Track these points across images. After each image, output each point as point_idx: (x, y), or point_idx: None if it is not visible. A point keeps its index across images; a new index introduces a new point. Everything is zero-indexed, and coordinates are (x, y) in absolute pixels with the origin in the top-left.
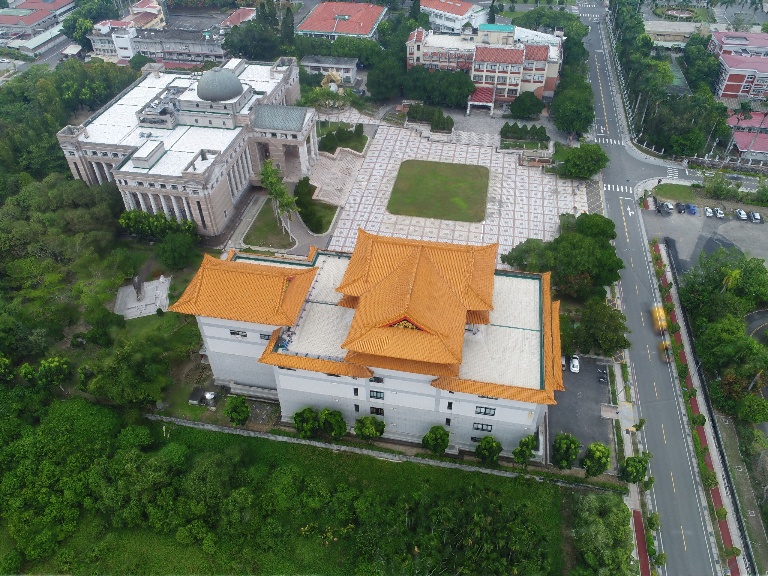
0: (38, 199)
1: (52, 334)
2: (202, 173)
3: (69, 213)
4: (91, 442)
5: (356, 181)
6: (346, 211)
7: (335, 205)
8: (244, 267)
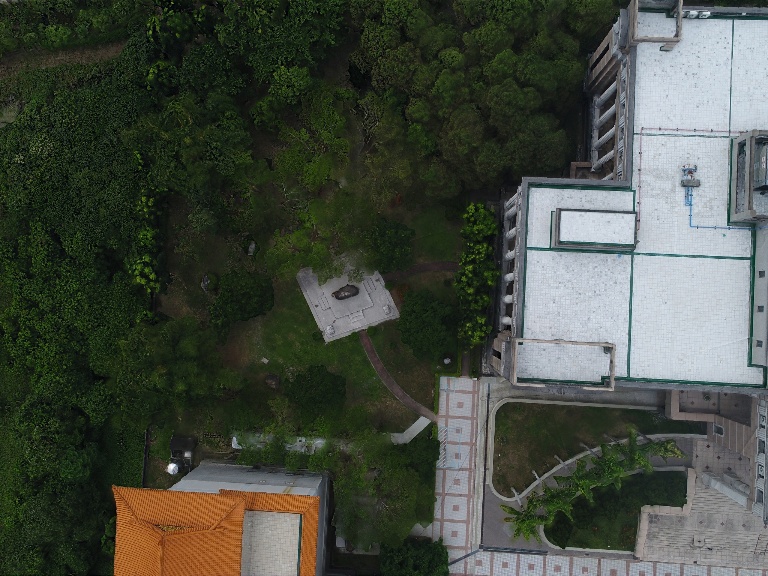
0: (496, 35)
1: (223, 225)
2: (516, 384)
3: (464, 115)
4: (86, 356)
5: (737, 570)
6: (626, 567)
7: (636, 547)
8: (216, 575)
